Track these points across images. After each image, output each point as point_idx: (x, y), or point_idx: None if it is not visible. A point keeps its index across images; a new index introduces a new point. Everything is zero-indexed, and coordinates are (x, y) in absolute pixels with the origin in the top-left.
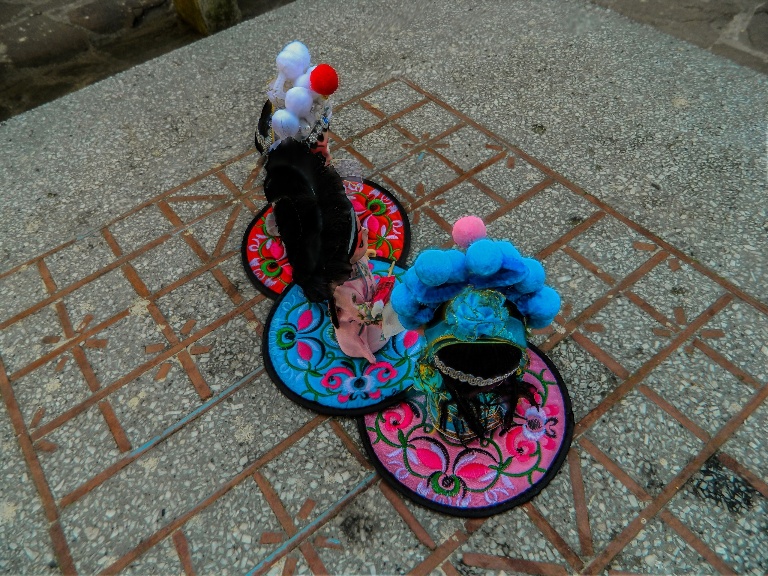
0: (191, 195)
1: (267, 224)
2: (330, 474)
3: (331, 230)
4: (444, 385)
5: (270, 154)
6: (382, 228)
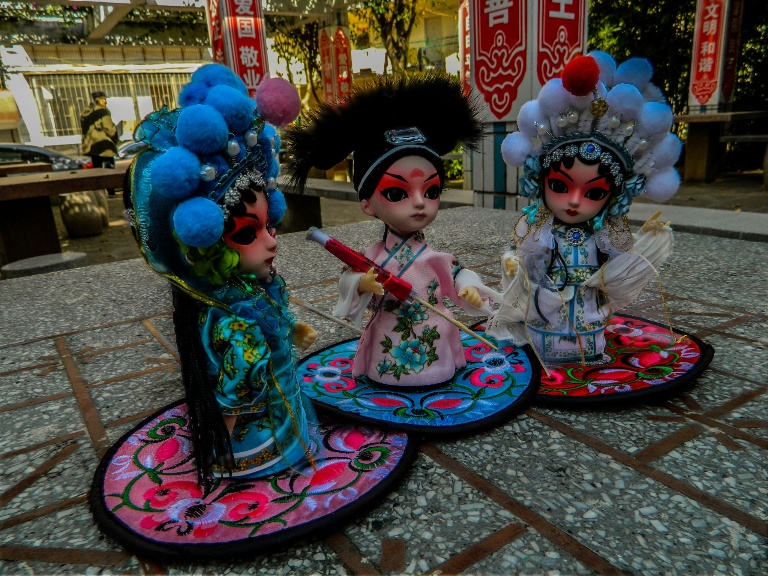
0: None
1: None
2: None
3: None
4: None
5: None
6: (609, 380)
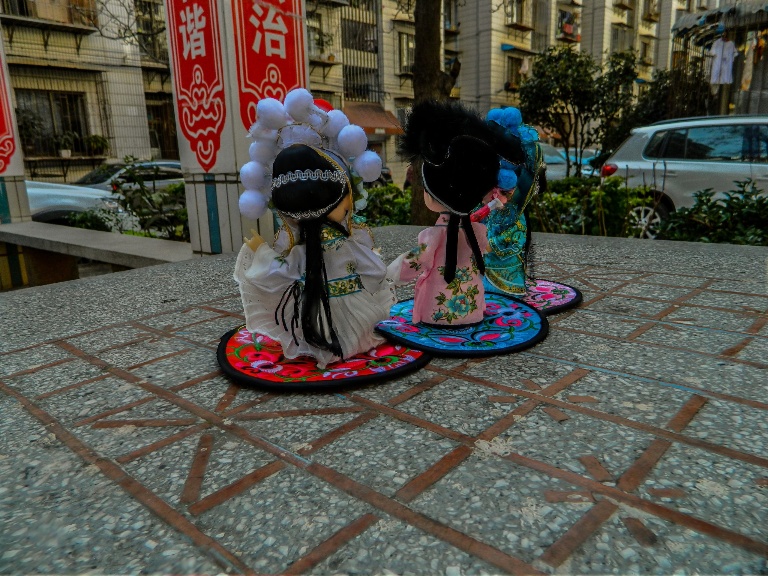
0: (186, 473)
1: (317, 355)
2: None
3: (494, 123)
4: None
5: (409, 130)
6: None
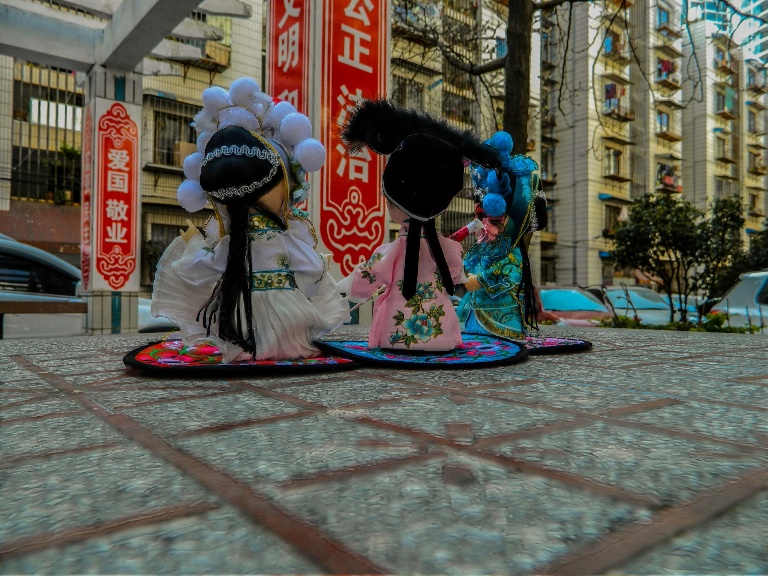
0: None
1: (218, 343)
2: (591, 358)
3: (467, 132)
4: (522, 256)
5: (356, 119)
6: None
